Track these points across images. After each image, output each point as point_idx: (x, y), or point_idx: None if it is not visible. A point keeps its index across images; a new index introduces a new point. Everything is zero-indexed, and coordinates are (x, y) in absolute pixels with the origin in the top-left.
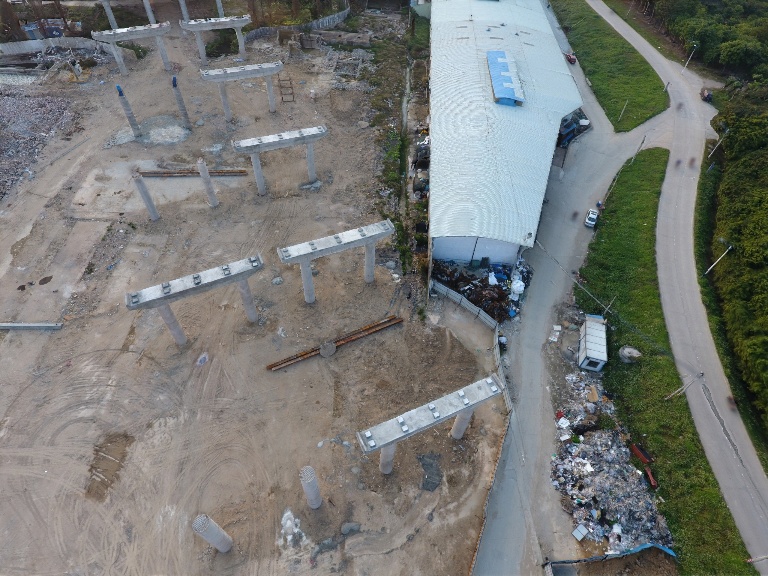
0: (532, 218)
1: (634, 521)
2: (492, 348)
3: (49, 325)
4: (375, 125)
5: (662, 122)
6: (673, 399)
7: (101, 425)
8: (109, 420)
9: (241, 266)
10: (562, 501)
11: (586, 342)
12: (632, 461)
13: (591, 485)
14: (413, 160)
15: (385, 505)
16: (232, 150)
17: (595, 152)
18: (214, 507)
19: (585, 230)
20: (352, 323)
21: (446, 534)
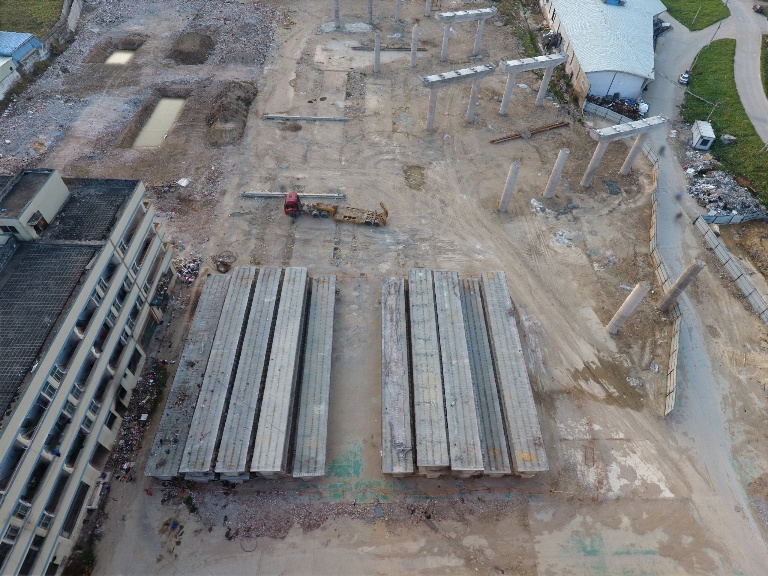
0: (649, 66)
1: (745, 208)
2: (633, 138)
3: (341, 118)
4: (508, 24)
5: (726, 24)
6: (763, 153)
7: (401, 162)
8: (404, 160)
9: (482, 68)
10: (698, 201)
11: (699, 129)
12: (739, 184)
13: (716, 192)
14: (546, 43)
15: (590, 199)
16: (409, 37)
17: (678, 42)
18: (488, 196)
19: (680, 85)
20: (536, 124)
21: (631, 211)
